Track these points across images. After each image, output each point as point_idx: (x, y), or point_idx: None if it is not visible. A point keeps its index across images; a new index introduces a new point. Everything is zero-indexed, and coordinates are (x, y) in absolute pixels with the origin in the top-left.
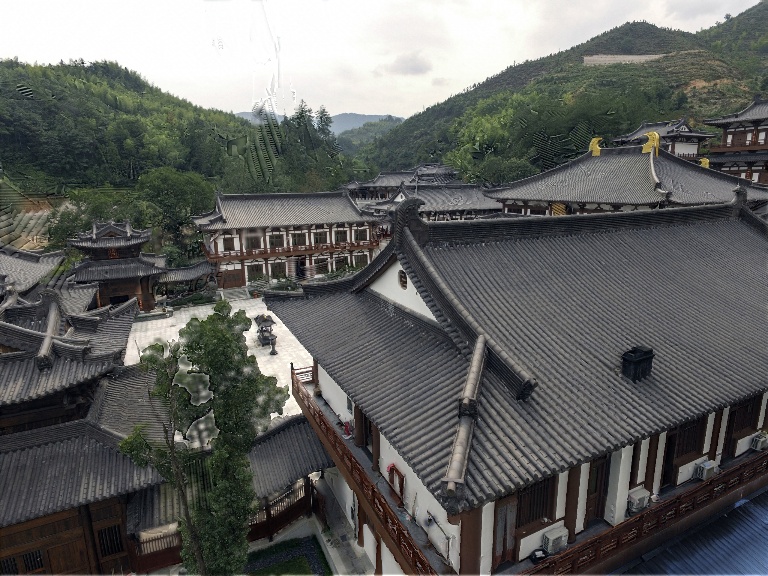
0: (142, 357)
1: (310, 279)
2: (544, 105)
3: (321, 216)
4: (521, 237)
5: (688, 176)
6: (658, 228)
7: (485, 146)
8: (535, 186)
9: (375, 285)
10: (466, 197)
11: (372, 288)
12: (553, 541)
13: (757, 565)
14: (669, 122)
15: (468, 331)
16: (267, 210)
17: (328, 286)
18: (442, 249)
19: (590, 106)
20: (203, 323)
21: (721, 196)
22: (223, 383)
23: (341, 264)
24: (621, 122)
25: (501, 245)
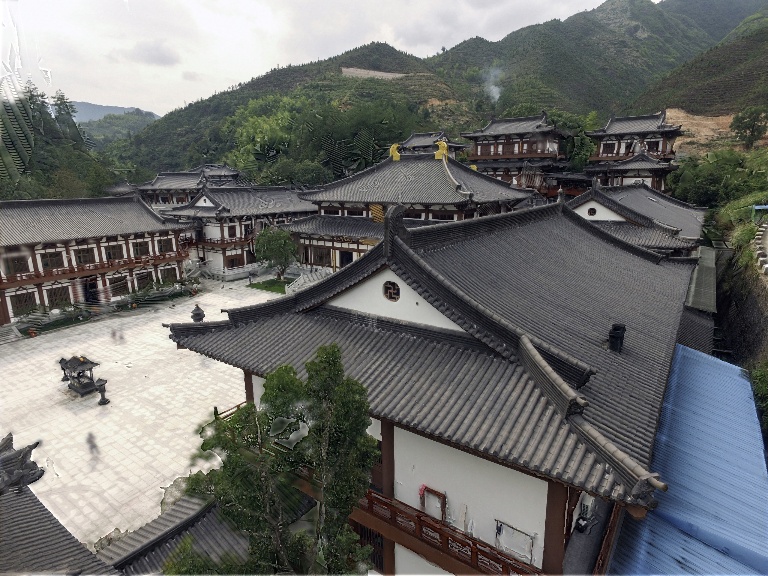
0: (207, 444)
1: (105, 303)
2: (327, 111)
3: (112, 226)
4: (465, 239)
5: (471, 179)
6: (530, 224)
7: (266, 147)
8: (348, 188)
9: (339, 301)
10: (274, 200)
11: (333, 304)
12: (591, 506)
13: (679, 473)
14: (433, 133)
15: (505, 334)
16: (31, 221)
17: (264, 308)
18: (420, 256)
19: (368, 115)
20: (287, 378)
21: (497, 196)
22: (352, 448)
23: (144, 281)
24: (394, 131)
25: (456, 248)
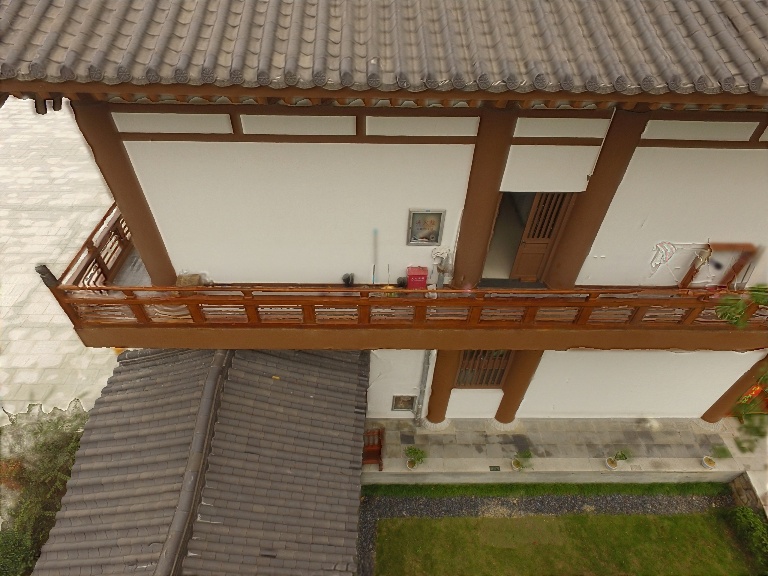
0: None
1: None
2: None
3: None
4: None
5: None
6: None
7: None
8: None
9: None
10: None
11: None
12: None
13: None
14: None
15: None
16: None
17: None
18: None
19: None
20: None
21: None
22: None
23: None
24: None
25: None
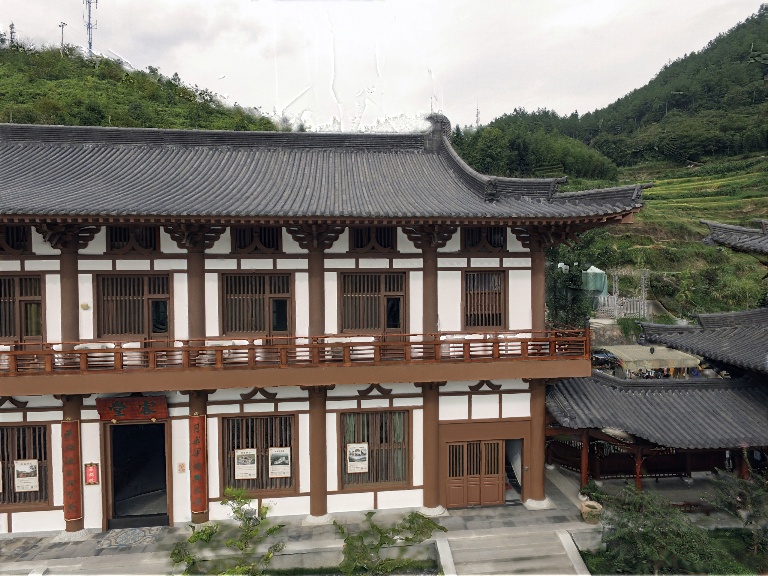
0: None
1: None
2: None
3: None
4: None
5: None
6: None
7: None
8: None
9: None
10: None
11: None
12: None
13: None
14: None
15: None
16: None
17: (515, 185)
18: None
19: None
20: None
21: None
22: None
23: None
24: None
25: None
